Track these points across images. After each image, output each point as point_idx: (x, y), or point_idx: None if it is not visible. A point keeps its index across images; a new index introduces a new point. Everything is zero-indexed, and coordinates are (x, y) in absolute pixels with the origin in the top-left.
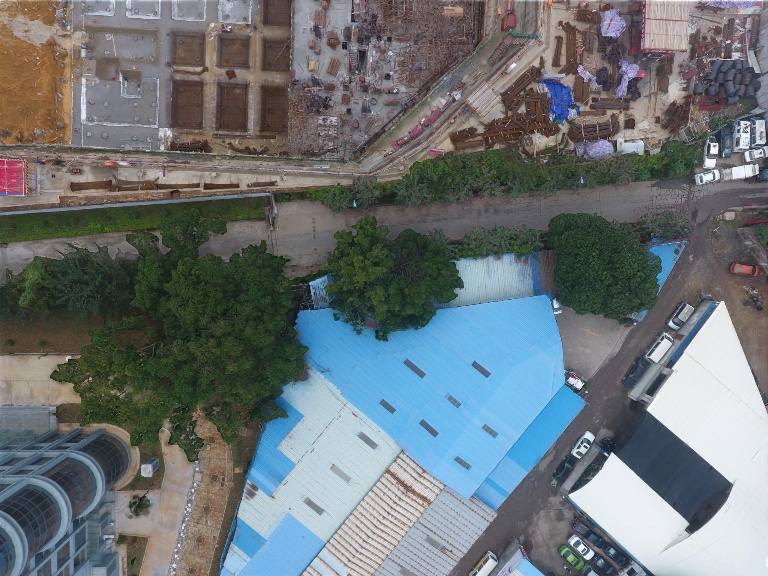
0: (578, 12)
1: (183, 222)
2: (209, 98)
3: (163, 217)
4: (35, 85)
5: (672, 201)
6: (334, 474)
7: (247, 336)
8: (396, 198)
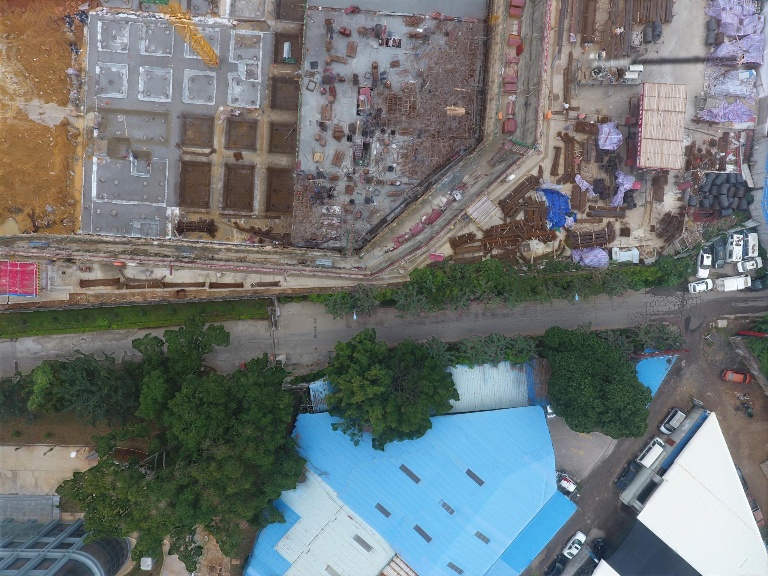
0: (577, 124)
1: (188, 334)
2: (216, 179)
3: (169, 315)
4: (48, 165)
5: (666, 308)
6: (329, 575)
7: (247, 456)
8: (395, 305)
